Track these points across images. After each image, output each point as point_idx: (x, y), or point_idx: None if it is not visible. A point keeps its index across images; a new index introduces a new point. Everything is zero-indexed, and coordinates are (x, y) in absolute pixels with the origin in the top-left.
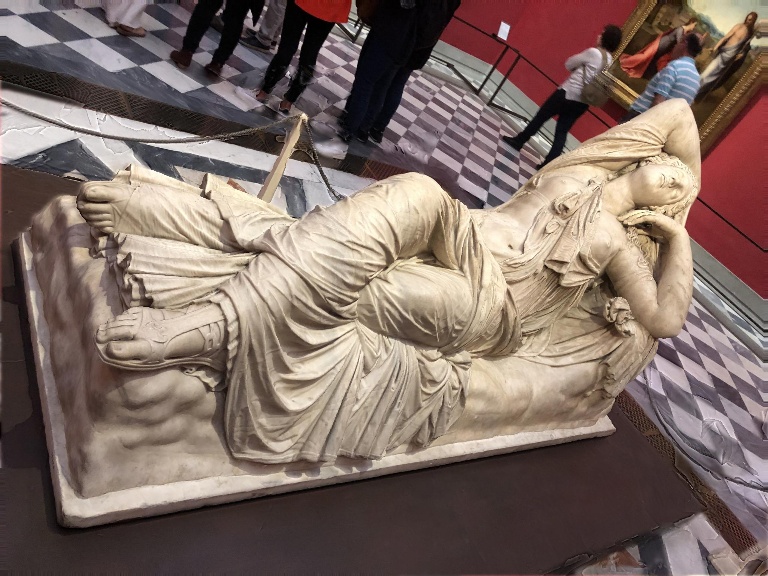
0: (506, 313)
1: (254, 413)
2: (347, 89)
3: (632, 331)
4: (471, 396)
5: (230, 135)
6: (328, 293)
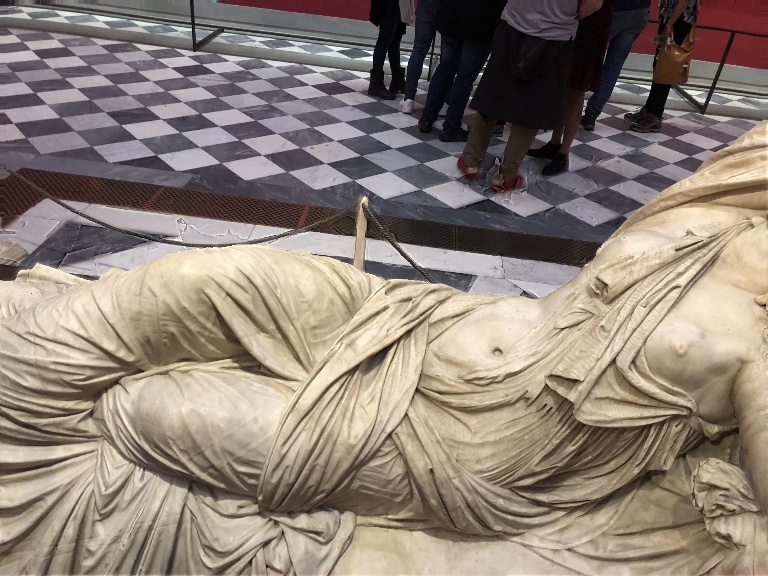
0: (406, 459)
1: None
2: (648, 167)
3: (739, 537)
4: None
5: (298, 231)
6: None
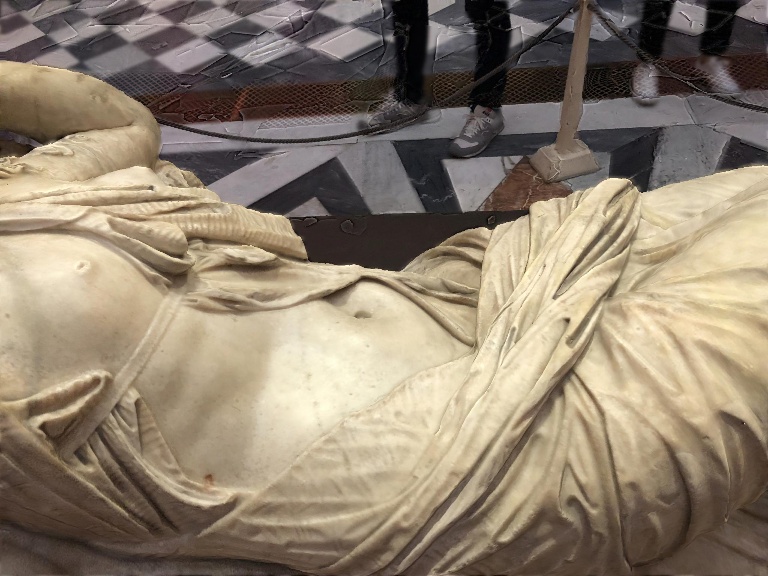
0: None
1: None
2: None
3: None
4: None
5: None
6: None
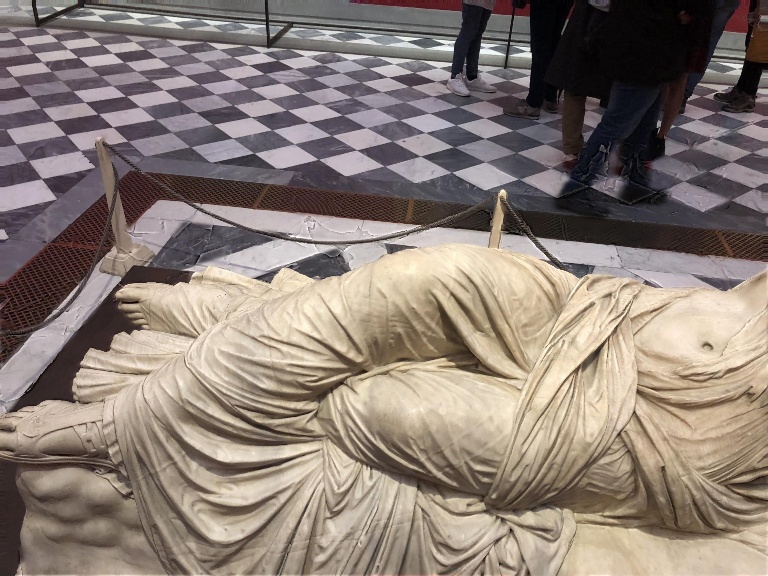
0: (636, 457)
1: (179, 534)
2: (747, 148)
3: None
4: None
5: (429, 226)
6: (234, 400)
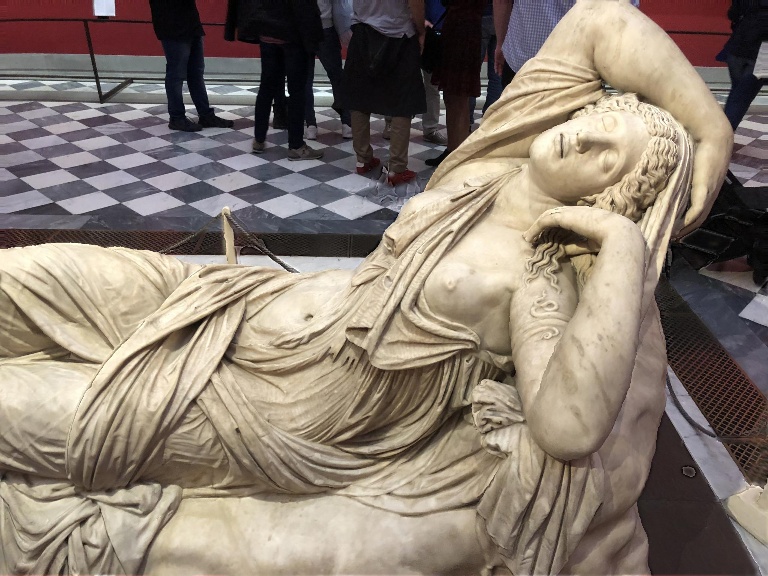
0: (212, 423)
1: None
2: None
3: (506, 446)
4: (170, 560)
5: (170, 248)
6: None
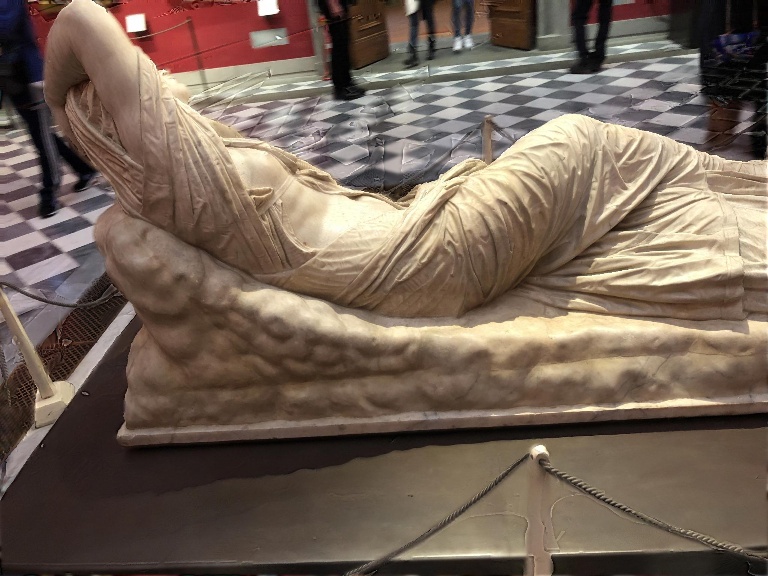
0: None
1: None
2: None
3: None
4: None
5: None
6: None
